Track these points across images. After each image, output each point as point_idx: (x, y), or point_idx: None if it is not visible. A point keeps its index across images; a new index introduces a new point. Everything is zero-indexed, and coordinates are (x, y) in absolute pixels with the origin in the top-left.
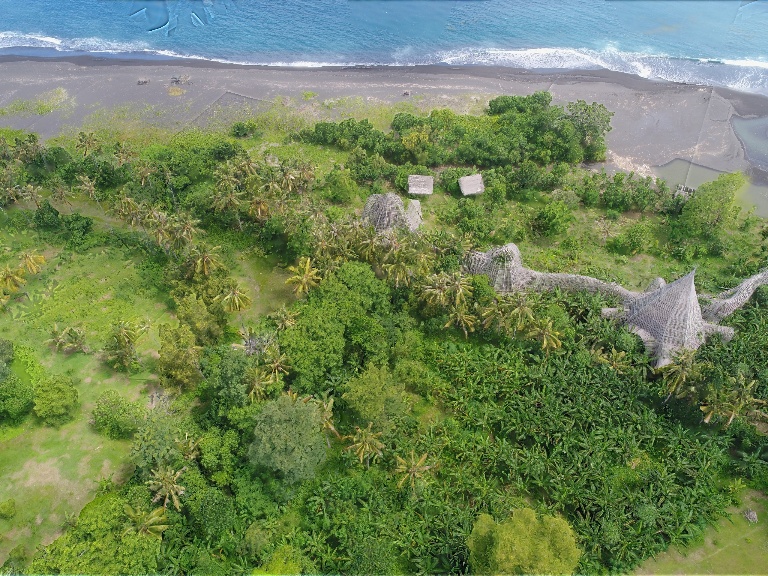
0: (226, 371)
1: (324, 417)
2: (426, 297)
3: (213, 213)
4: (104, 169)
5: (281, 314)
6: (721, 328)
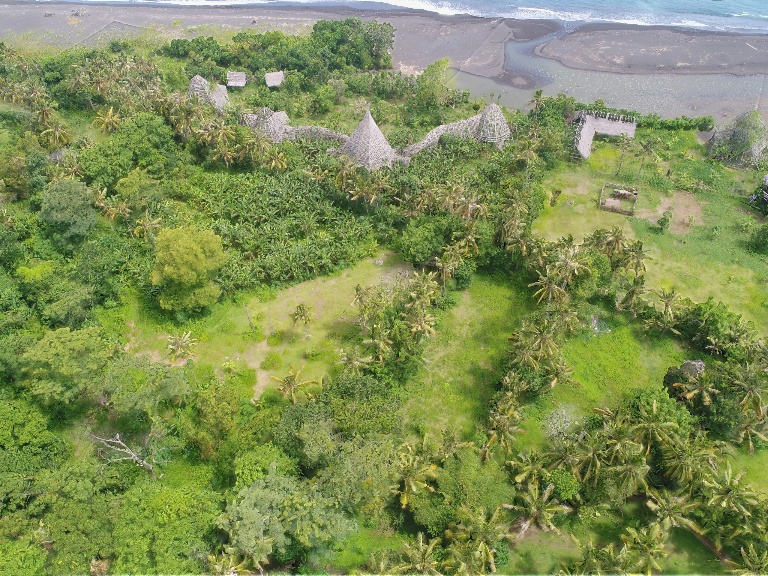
0: (28, 162)
1: (98, 199)
2: (198, 137)
3: (74, 97)
4: None
5: (83, 139)
6: (402, 157)
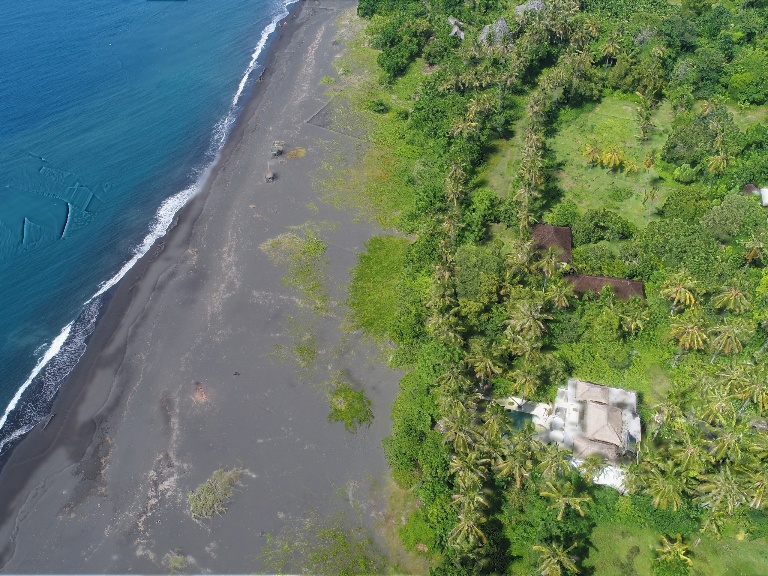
0: None
1: None
2: None
3: None
4: None
5: None
6: None
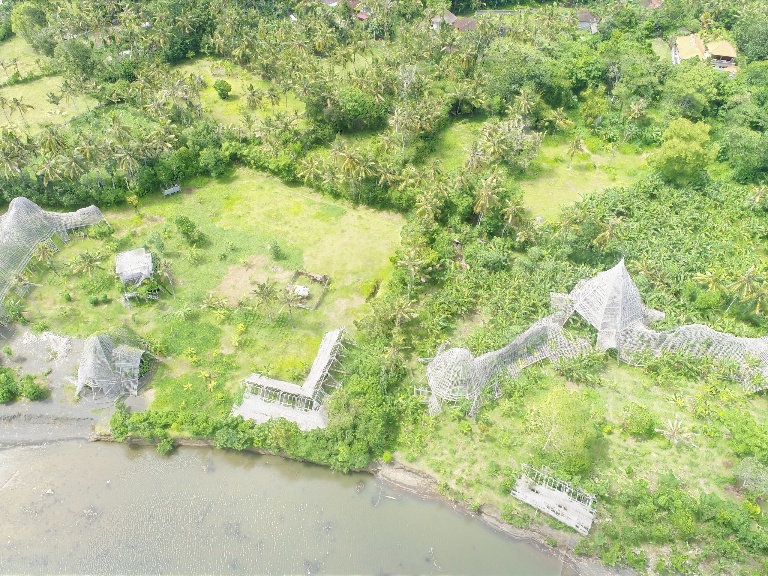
0: None
1: None
2: None
3: None
4: None
5: None
6: (562, 294)
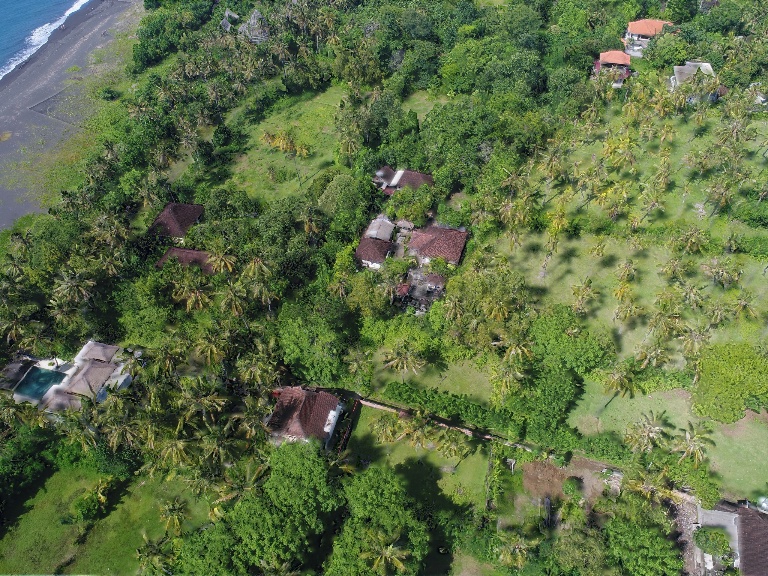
0: None
1: None
2: None
3: None
4: (159, 124)
5: None
6: None
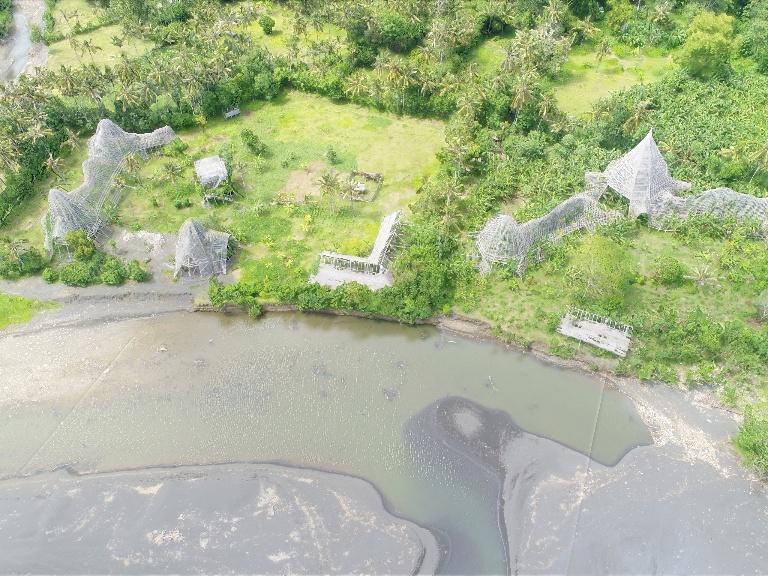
0: None
1: None
2: None
3: None
4: None
5: None
6: (595, 173)
